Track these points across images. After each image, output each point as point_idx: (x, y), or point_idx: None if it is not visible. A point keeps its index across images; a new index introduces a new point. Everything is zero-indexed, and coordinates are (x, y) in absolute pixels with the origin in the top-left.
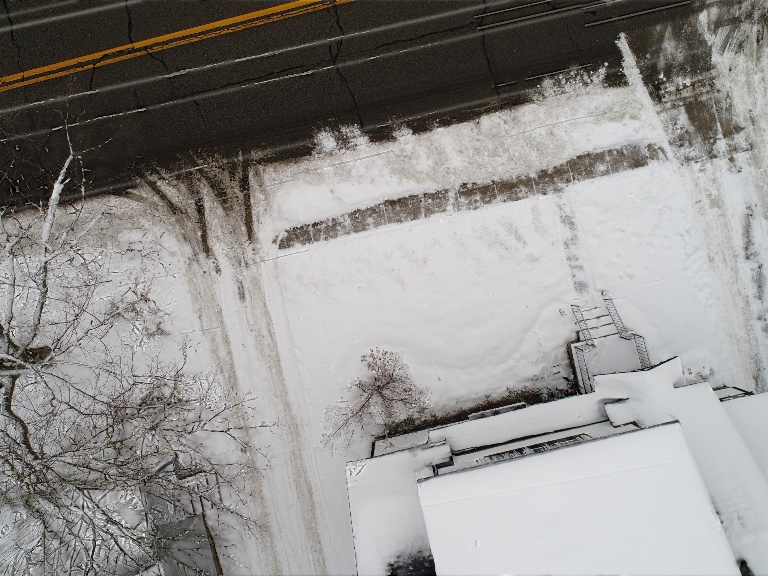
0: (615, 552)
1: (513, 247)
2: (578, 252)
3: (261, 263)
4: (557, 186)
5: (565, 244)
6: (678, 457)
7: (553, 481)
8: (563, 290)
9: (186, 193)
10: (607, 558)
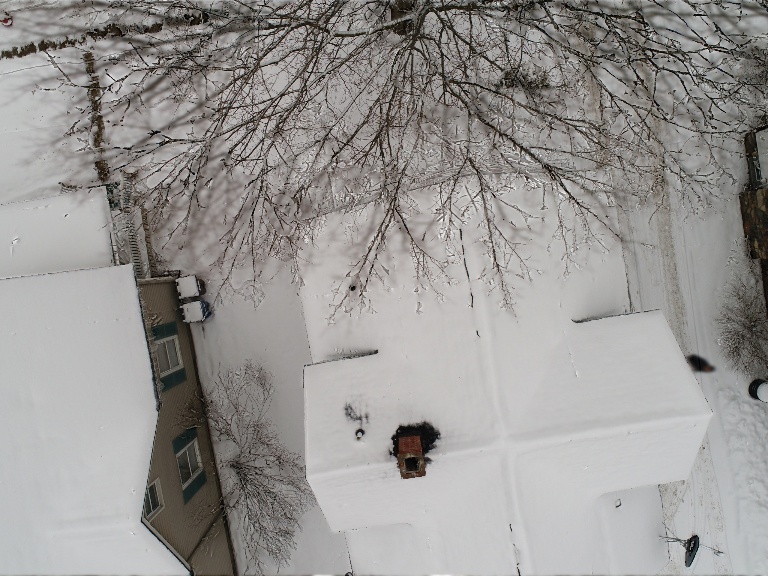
0: None
1: None
2: None
3: None
4: None
5: None
6: None
7: None
8: None
9: None
10: None
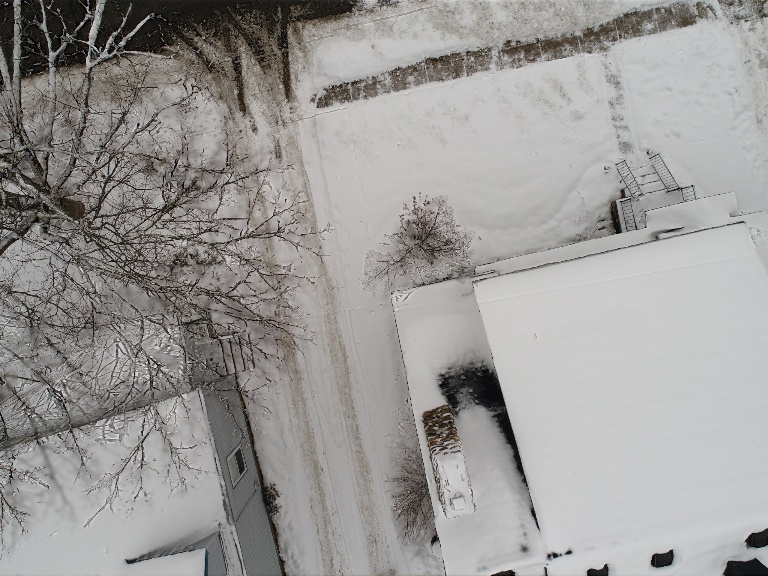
0: (681, 341)
1: (557, 104)
2: (623, 112)
3: (299, 121)
4: (603, 44)
5: (610, 104)
6: (744, 253)
7: (615, 277)
8: (608, 149)
9: (223, 50)
10: (672, 347)
